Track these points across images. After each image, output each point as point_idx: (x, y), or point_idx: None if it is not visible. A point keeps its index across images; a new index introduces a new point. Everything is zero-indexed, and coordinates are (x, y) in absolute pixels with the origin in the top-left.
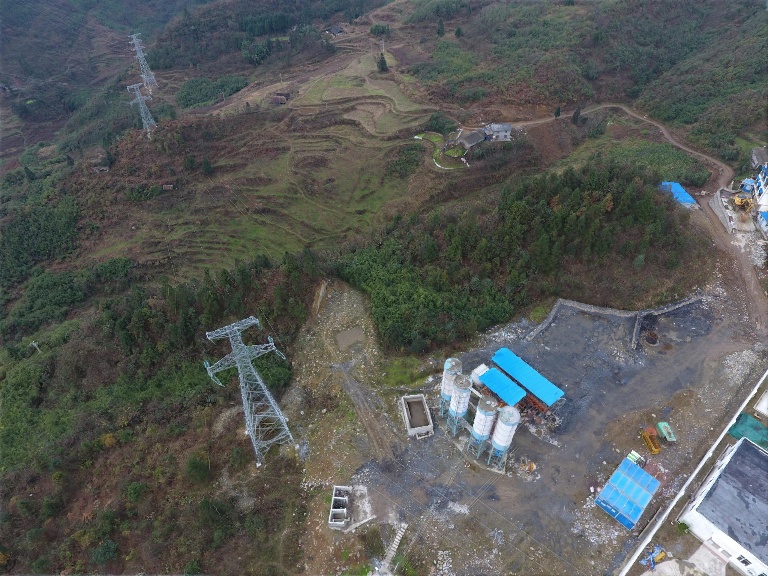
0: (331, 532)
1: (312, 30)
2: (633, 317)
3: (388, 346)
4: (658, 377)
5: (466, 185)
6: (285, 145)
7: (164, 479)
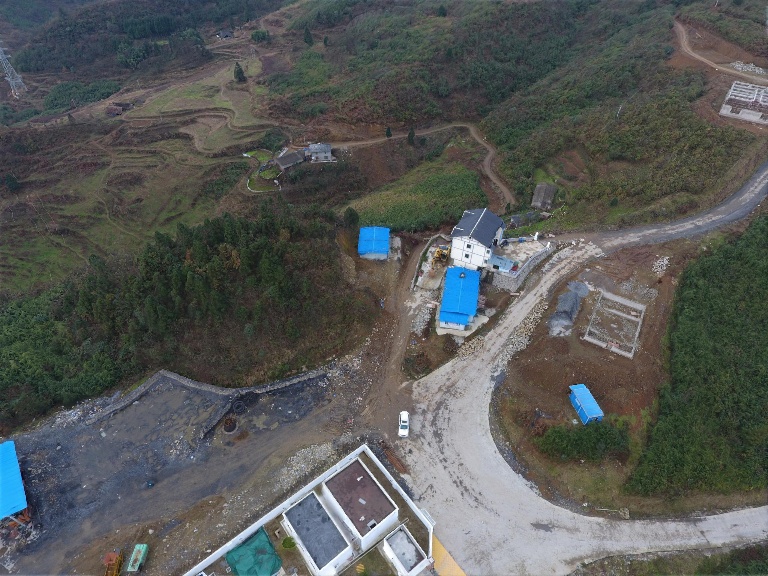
0: None
1: (194, 34)
2: (230, 395)
3: None
4: (197, 477)
5: None
6: (105, 160)
7: None
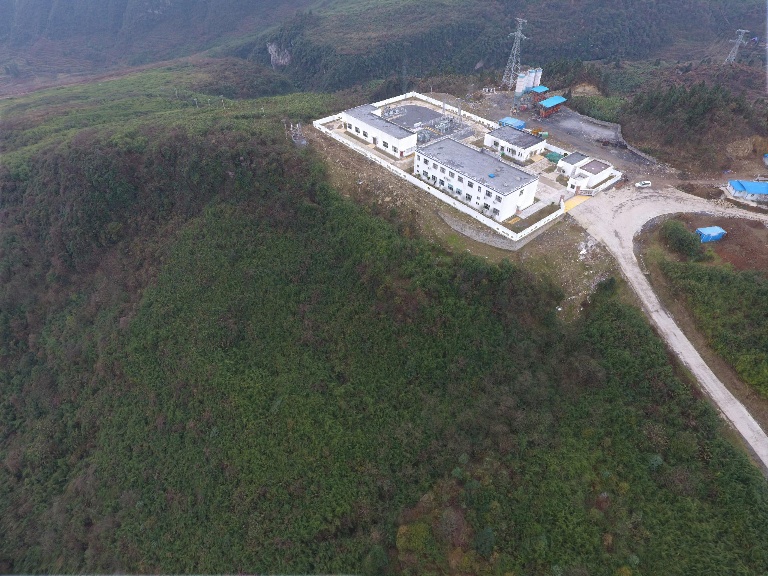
0: None
1: None
2: None
3: None
4: (578, 141)
5: None
6: None
7: None
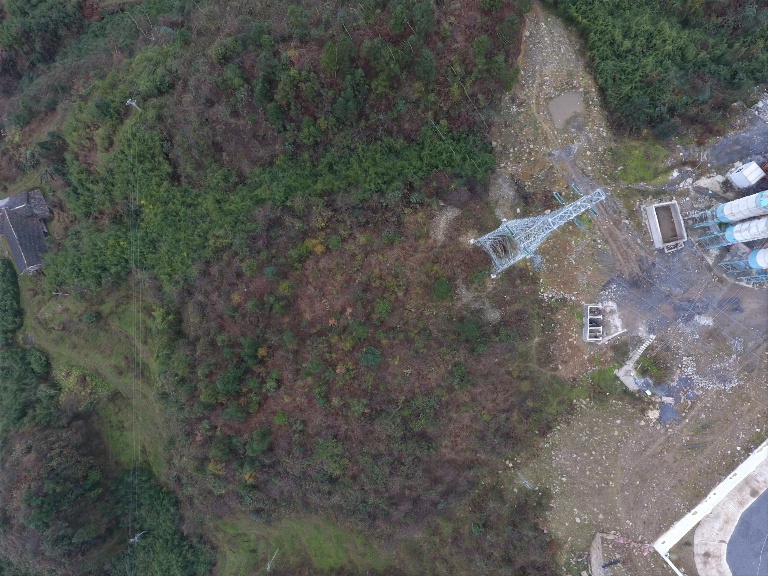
0: (586, 344)
1: None
2: None
3: (620, 124)
4: None
5: None
6: None
7: (401, 292)
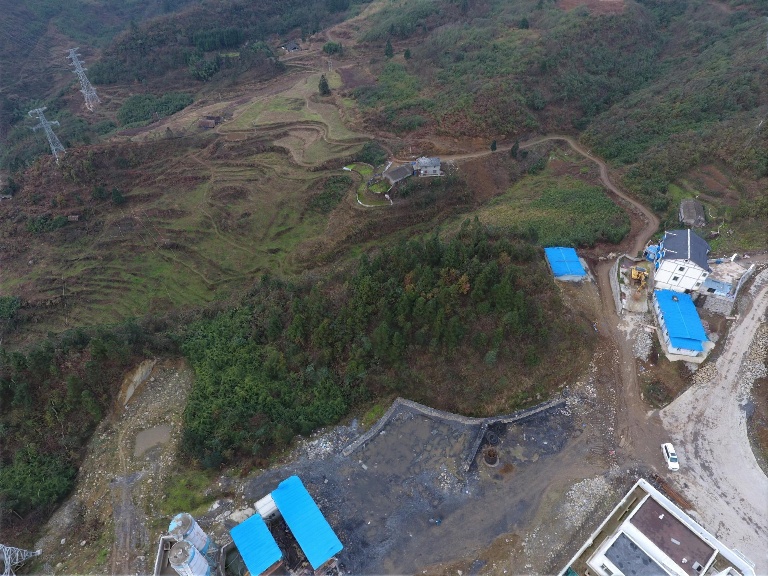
0: None
1: (264, 46)
2: (478, 425)
3: (186, 454)
4: (482, 514)
5: (388, 224)
6: (206, 174)
7: None
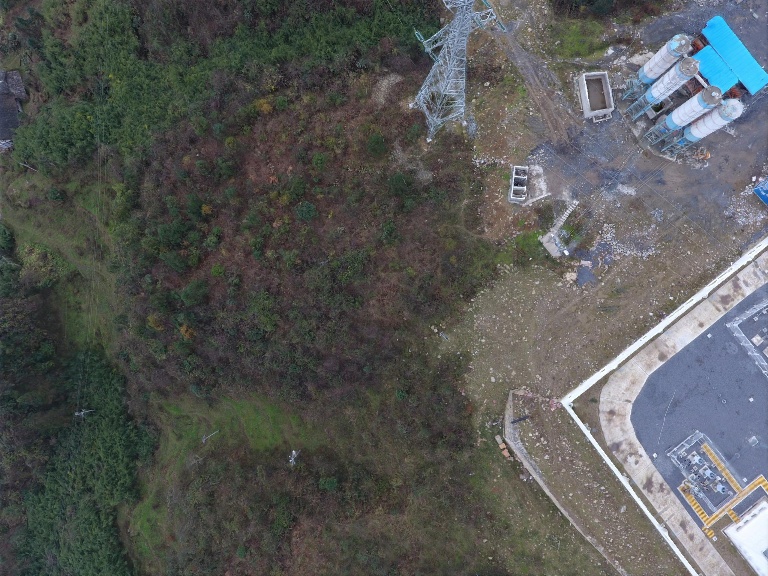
0: (510, 205)
1: None
2: None
3: (561, 2)
4: None
5: None
6: None
7: (340, 150)
